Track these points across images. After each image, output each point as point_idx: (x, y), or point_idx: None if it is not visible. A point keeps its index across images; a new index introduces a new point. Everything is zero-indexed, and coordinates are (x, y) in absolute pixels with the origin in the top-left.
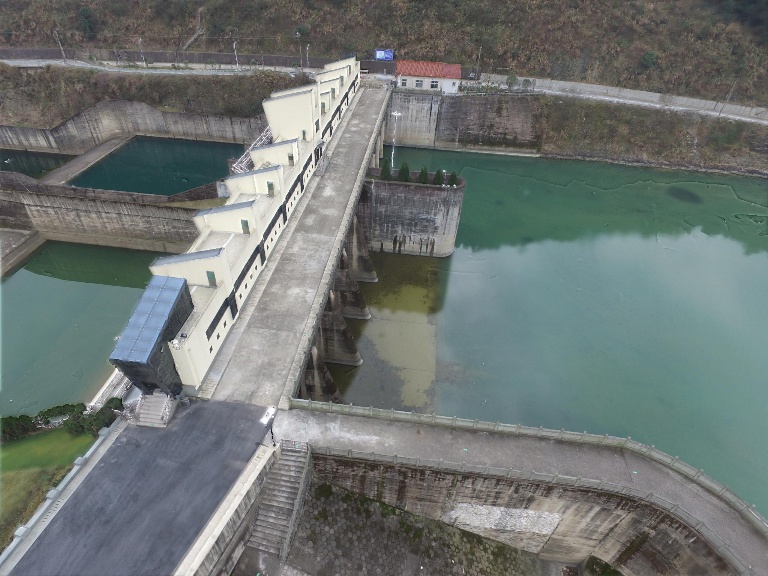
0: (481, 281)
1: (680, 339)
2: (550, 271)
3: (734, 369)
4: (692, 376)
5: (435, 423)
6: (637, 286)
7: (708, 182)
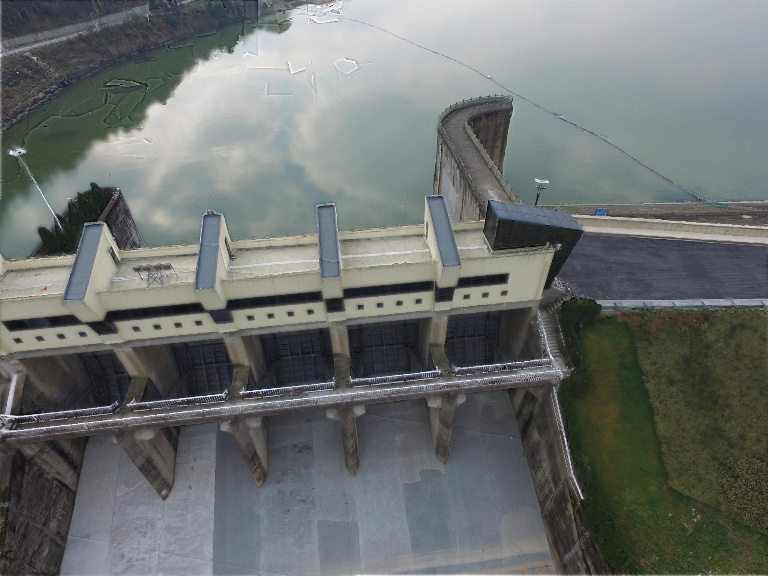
0: None
1: (272, 161)
2: (185, 209)
3: (297, 148)
4: (307, 162)
5: None
6: (209, 171)
7: (21, 131)
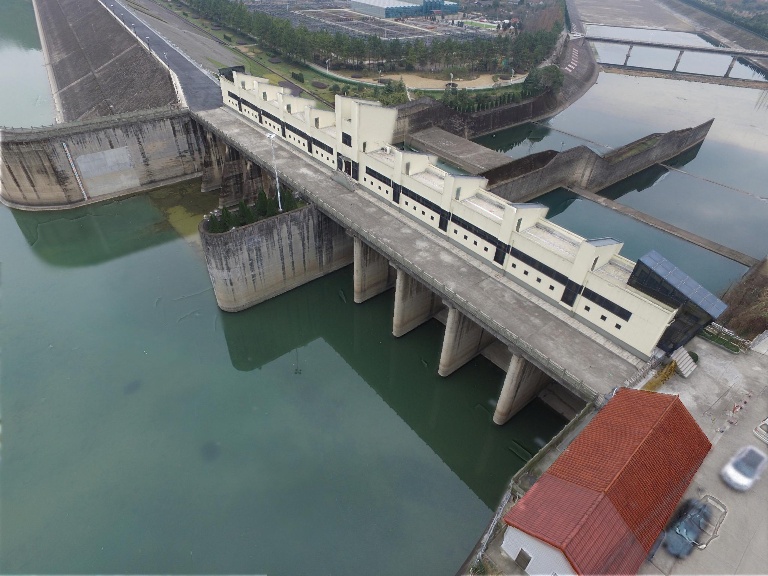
0: (169, 291)
1: None
2: (91, 351)
3: None
4: None
5: (128, 123)
6: None
7: None
